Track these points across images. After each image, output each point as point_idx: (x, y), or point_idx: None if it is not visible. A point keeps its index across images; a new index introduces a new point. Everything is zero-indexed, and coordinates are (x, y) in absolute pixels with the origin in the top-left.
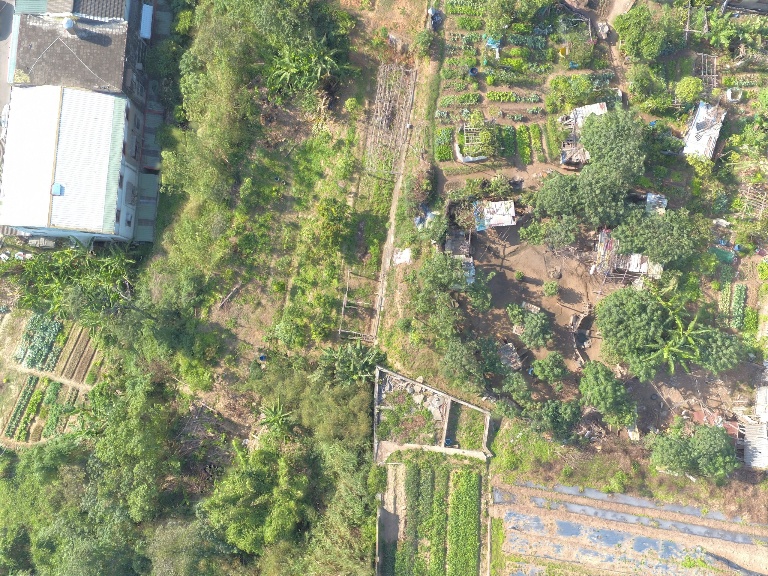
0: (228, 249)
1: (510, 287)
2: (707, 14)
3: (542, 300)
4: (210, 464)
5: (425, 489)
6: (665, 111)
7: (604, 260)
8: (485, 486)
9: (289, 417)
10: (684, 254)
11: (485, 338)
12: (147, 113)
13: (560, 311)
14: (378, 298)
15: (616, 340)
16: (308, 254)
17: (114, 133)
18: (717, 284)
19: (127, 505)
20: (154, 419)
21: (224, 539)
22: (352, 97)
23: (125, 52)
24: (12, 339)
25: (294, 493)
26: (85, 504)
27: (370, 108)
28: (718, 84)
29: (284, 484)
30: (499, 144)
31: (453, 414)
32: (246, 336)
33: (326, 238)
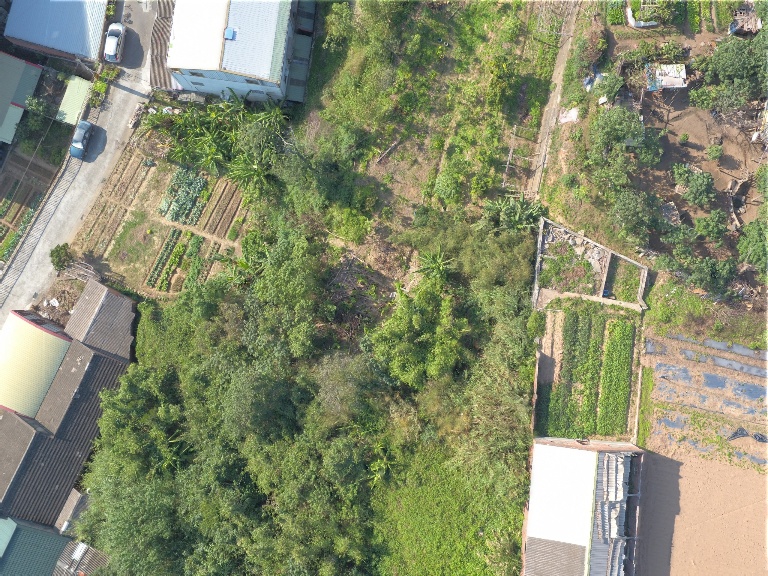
0: (389, 106)
1: (672, 150)
2: None
3: (702, 165)
4: (358, 314)
5: (582, 335)
6: None
7: None
8: (639, 336)
9: (449, 265)
10: None
11: None
12: None
13: (719, 176)
14: (542, 155)
15: None
16: (468, 114)
17: None
18: None
19: (287, 341)
20: None
21: (387, 372)
22: None
23: None
24: (157, 192)
25: (457, 332)
26: (246, 338)
27: None
28: None
29: (448, 323)
30: (675, 8)
31: (611, 268)
32: (401, 191)
33: (494, 94)
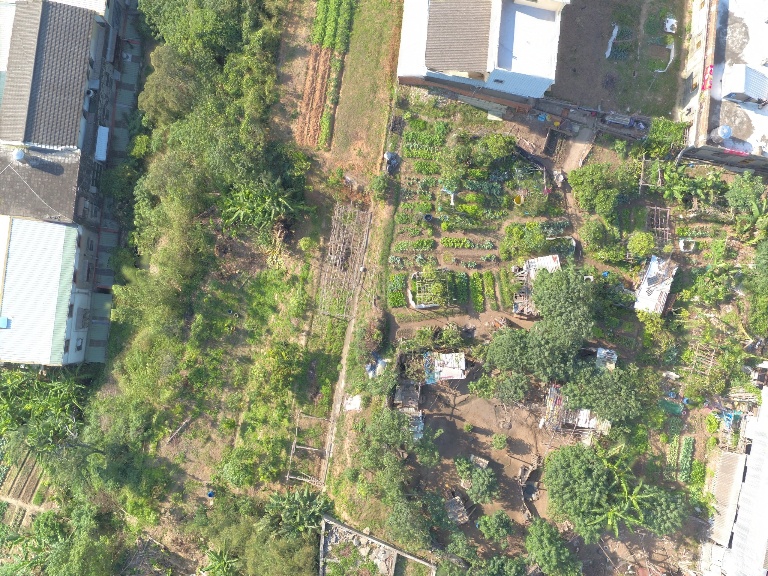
0: (178, 382)
1: (460, 437)
2: (661, 168)
3: (491, 451)
4: None
5: None
6: (618, 262)
7: (553, 415)
8: None
9: (234, 563)
10: (631, 415)
11: (433, 488)
12: (102, 231)
13: (509, 462)
14: (327, 444)
15: (562, 502)
16: (259, 390)
17: (64, 263)
18: (665, 438)
19: None
20: (99, 553)
21: None
22: (307, 233)
23: (77, 181)
24: None
25: None
26: None
27: (325, 245)
28: (671, 235)
29: None
30: (451, 295)
31: (399, 567)
32: (195, 471)
33: (276, 381)
